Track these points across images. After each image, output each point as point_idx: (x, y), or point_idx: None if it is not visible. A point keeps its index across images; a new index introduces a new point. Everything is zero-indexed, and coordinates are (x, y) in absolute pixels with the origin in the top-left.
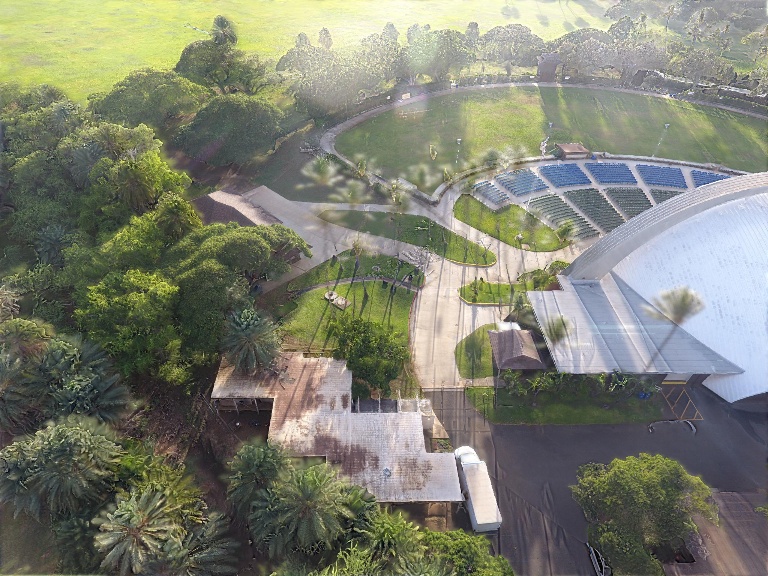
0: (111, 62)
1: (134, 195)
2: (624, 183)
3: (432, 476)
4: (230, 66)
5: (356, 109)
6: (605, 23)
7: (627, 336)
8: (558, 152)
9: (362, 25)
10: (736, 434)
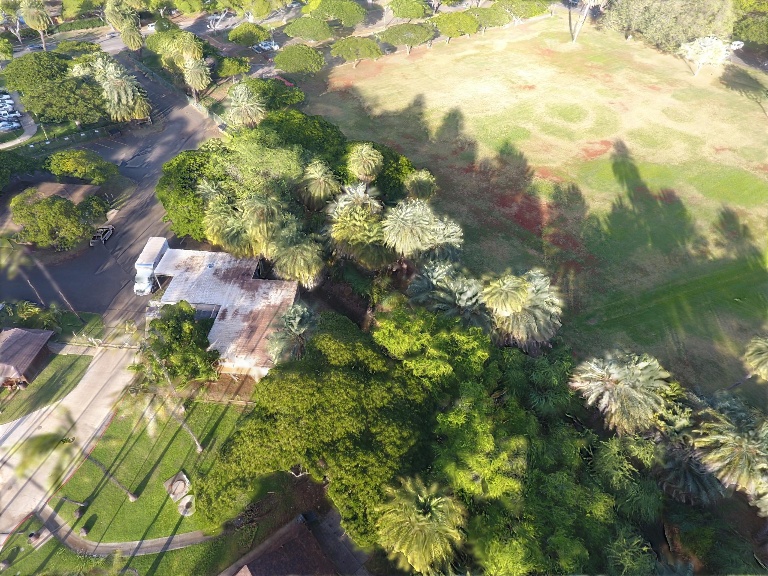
0: None
1: None
2: None
3: (179, 261)
4: None
5: None
6: None
7: None
8: None
9: None
10: None
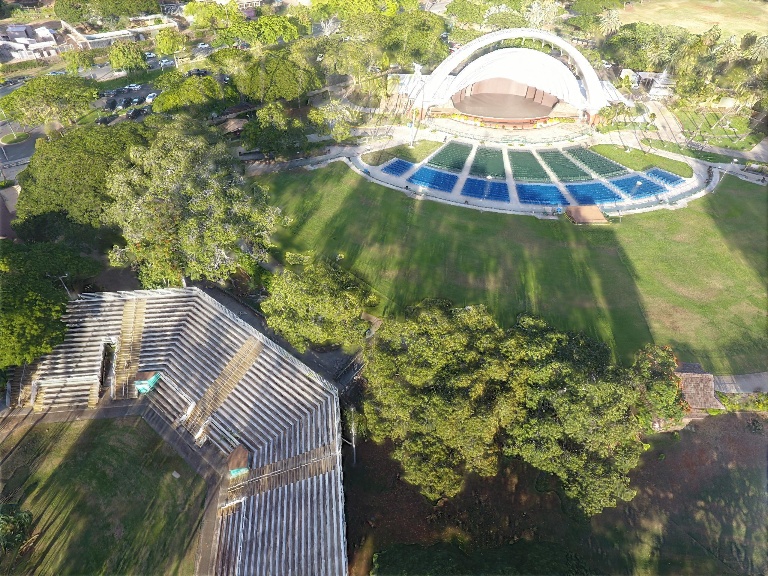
0: None
1: None
2: None
3: None
4: None
5: None
6: None
7: None
8: None
9: None
10: None
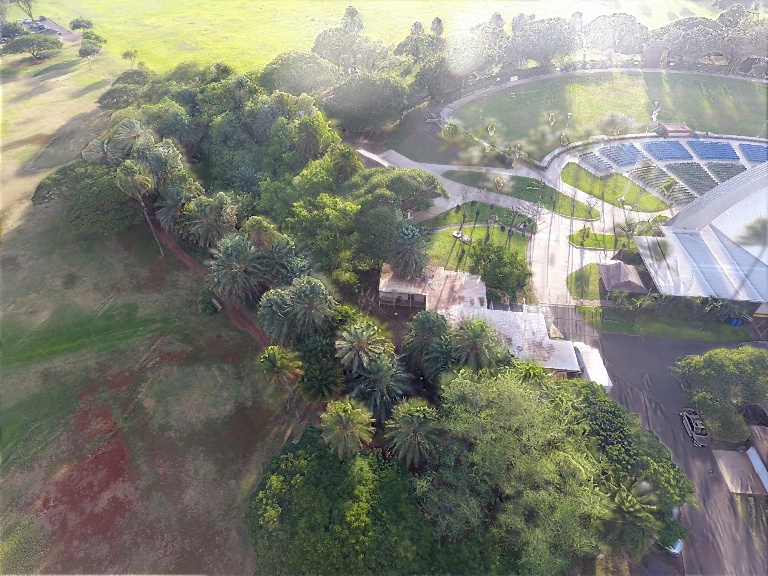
0: (248, 48)
1: (308, 145)
2: (726, 159)
3: (555, 354)
4: (358, 50)
5: (470, 88)
6: (713, 13)
7: (724, 273)
8: (661, 130)
9: (464, 16)
10: None
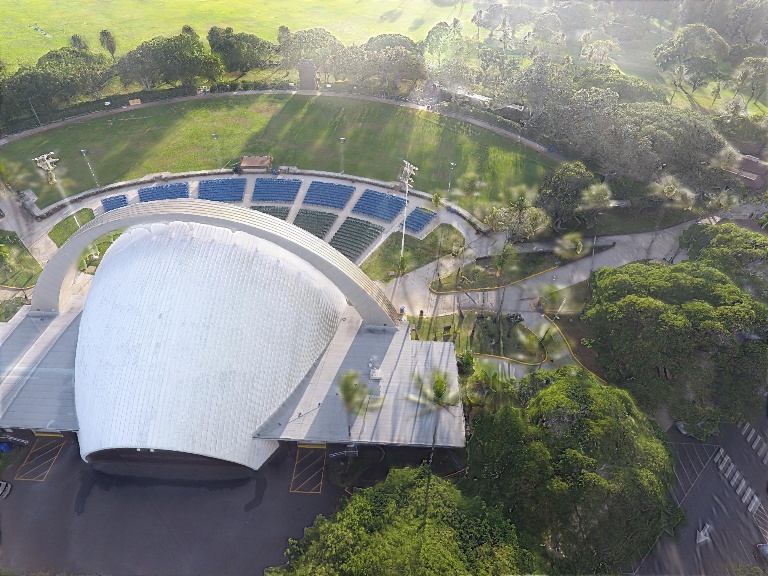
0: None
1: None
2: (279, 201)
3: None
4: None
5: (56, 115)
6: (480, 28)
7: (2, 380)
8: None
9: None
10: (60, 501)
